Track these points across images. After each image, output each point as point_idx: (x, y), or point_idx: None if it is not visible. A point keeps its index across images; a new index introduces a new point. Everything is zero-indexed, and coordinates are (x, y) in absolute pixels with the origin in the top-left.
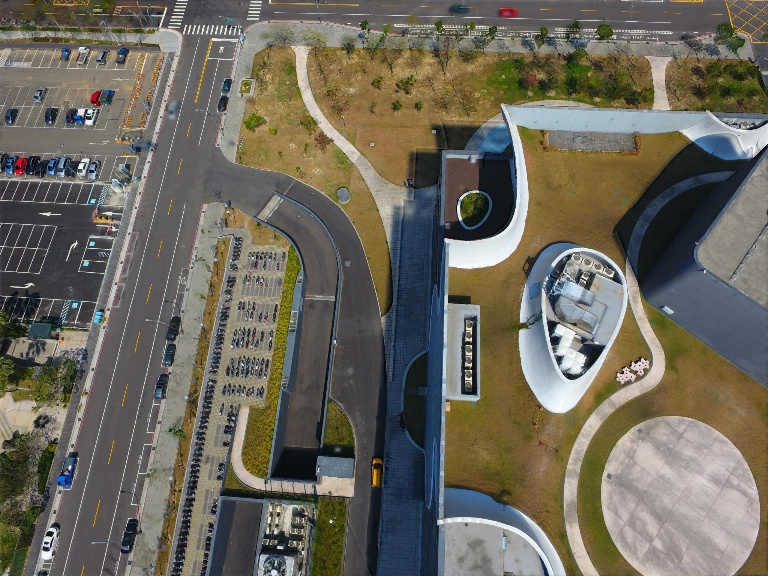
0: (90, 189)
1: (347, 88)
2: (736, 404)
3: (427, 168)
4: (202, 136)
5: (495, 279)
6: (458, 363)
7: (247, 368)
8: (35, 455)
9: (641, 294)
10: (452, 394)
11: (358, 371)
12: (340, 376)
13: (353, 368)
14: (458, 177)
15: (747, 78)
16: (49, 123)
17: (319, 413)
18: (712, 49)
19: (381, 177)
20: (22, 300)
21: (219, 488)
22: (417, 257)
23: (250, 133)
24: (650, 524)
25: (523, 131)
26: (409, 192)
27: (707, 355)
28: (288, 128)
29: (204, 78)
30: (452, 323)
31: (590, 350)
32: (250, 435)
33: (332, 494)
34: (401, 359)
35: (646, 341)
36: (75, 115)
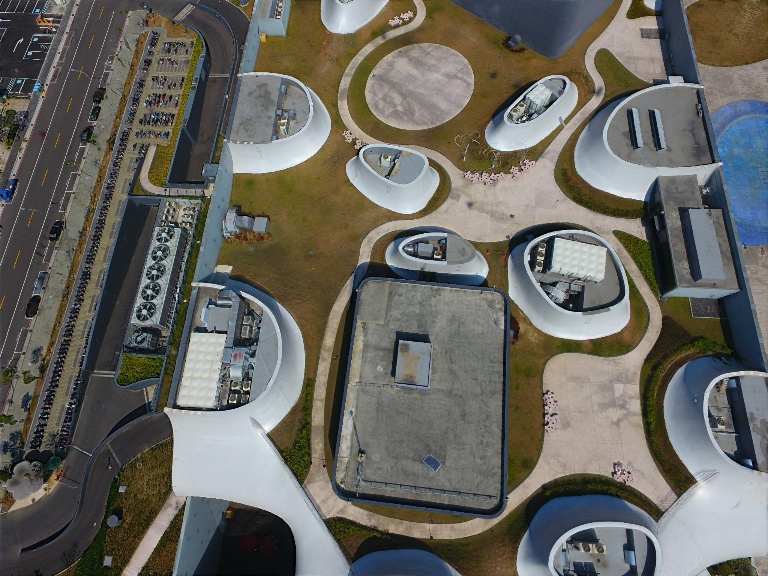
0: (35, 2)
1: None
2: (470, 35)
3: None
4: None
5: None
6: (269, 2)
7: (157, 119)
8: None
9: None
10: (262, 18)
11: None
12: None
13: None
14: None
15: None
16: None
17: None
18: None
19: None
20: None
21: None
22: None
23: None
24: (397, 99)
25: None
26: None
27: (457, 10)
28: None
29: None
30: None
31: None
32: (156, 162)
33: None
34: None
35: (414, 3)
36: None
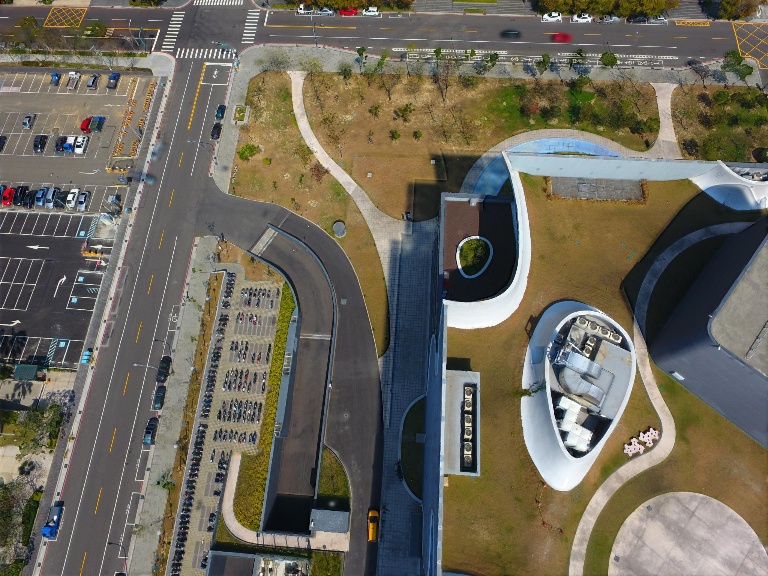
0: (79, 221)
1: (344, 115)
2: (751, 479)
3: (426, 200)
4: (195, 165)
5: (496, 340)
6: (457, 437)
7: (239, 412)
8: (19, 504)
9: (649, 357)
10: (450, 471)
11: (354, 416)
12: (335, 421)
13: (349, 413)
14: (457, 221)
15: (755, 106)
16: (38, 151)
17: (314, 458)
18: (719, 75)
19: (378, 210)
20: (8, 338)
21: (209, 540)
22: (415, 295)
23: (244, 162)
24: None
25: (525, 178)
26: (407, 226)
27: (719, 424)
28: (283, 157)
29: (197, 104)
30: (451, 392)
31: (596, 421)
32: (242, 484)
33: (326, 548)
34: (398, 404)
35: (655, 409)
36: (65, 143)
